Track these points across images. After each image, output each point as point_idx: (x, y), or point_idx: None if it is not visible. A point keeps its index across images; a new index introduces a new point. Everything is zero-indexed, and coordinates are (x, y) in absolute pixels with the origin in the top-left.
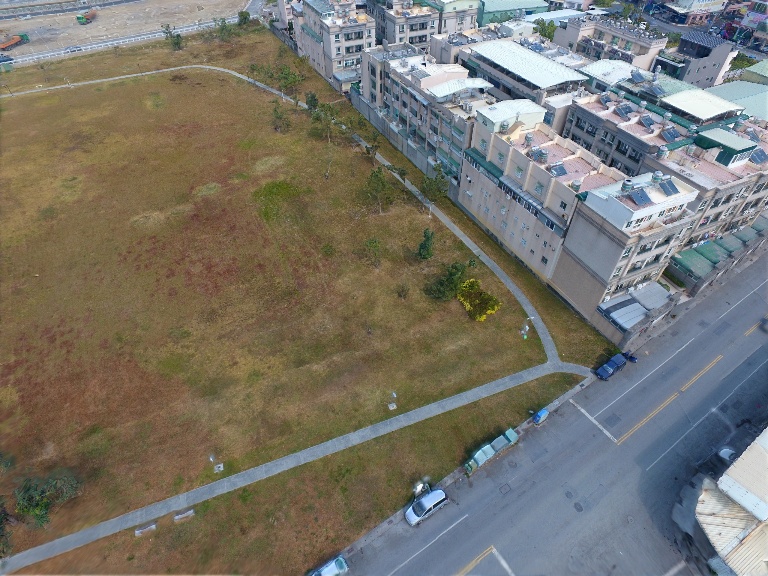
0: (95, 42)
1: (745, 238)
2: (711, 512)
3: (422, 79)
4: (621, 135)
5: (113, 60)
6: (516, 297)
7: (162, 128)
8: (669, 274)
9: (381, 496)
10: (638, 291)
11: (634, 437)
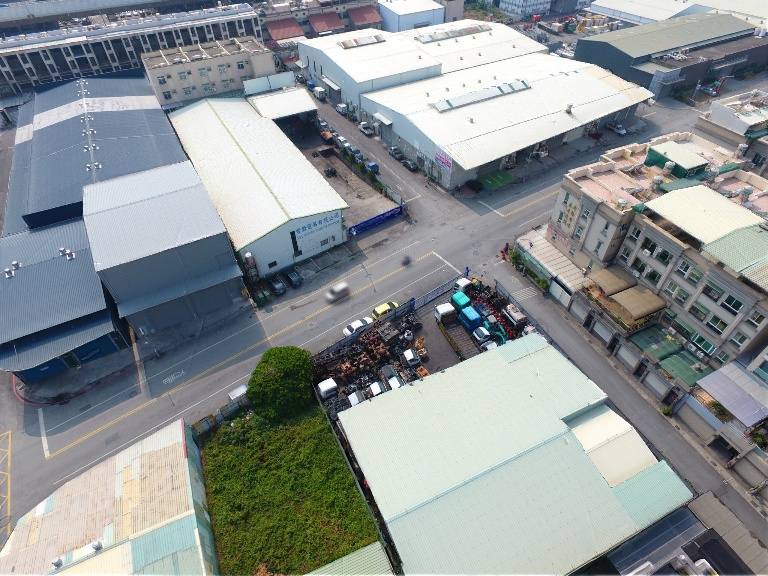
0: None
1: None
2: None
3: None
4: None
5: None
6: None
7: None
8: None
9: None
10: None
11: None
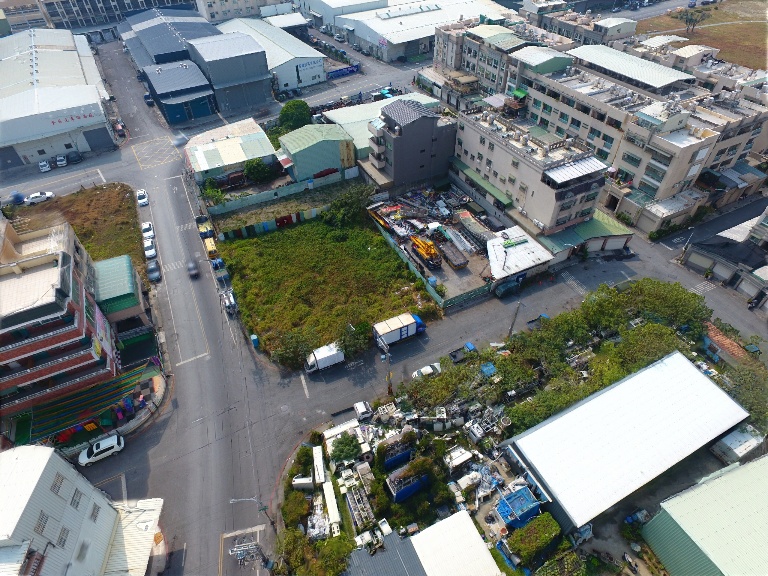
0: None
1: None
2: None
3: None
4: None
5: None
6: None
7: None
8: None
9: None
10: None
11: None
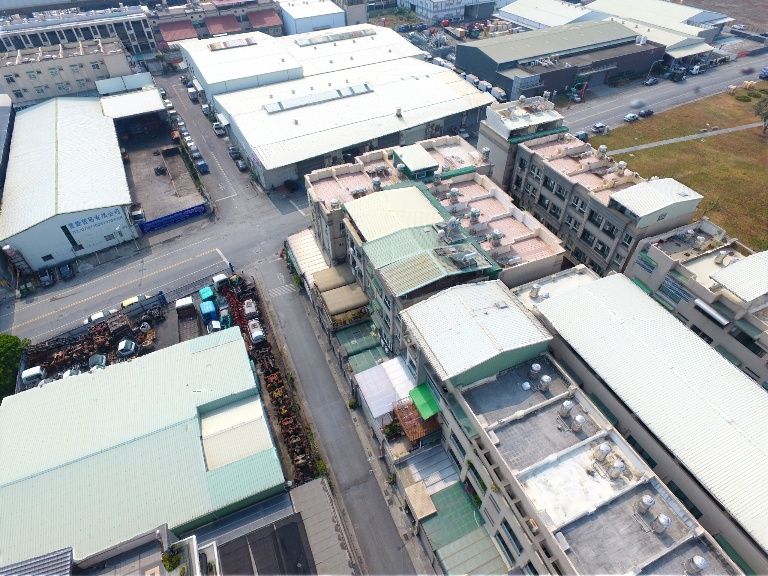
0: None
1: None
2: None
3: None
4: None
5: None
6: None
7: None
8: None
9: None
10: None
11: None
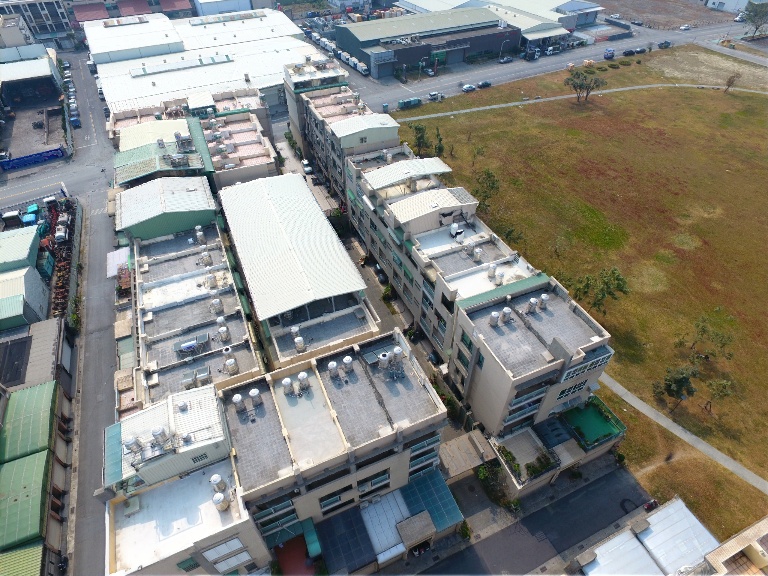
0: None
1: None
2: None
3: None
4: None
5: None
6: None
7: None
8: None
9: None
10: None
11: None
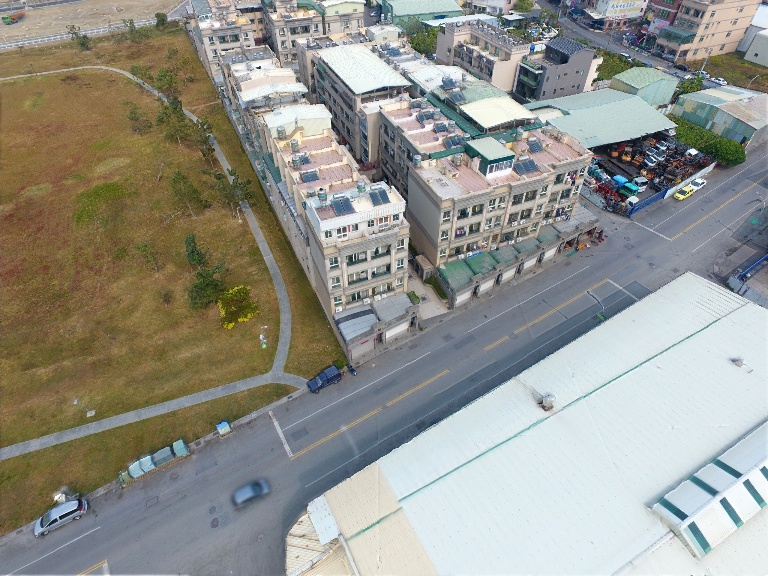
0: (9, 42)
1: (522, 250)
2: (302, 533)
3: (242, 83)
4: (406, 142)
5: (17, 60)
6: (280, 305)
7: (27, 128)
8: (437, 285)
9: (26, 505)
10: (379, 302)
11: (312, 452)
